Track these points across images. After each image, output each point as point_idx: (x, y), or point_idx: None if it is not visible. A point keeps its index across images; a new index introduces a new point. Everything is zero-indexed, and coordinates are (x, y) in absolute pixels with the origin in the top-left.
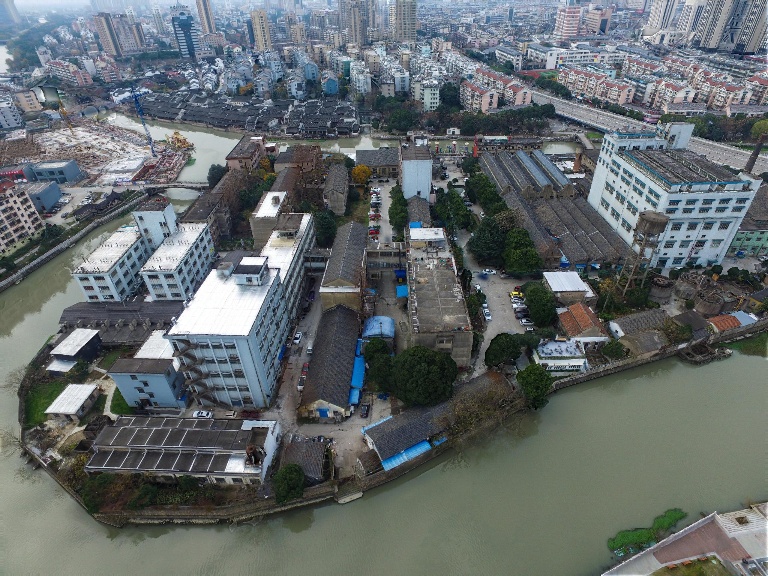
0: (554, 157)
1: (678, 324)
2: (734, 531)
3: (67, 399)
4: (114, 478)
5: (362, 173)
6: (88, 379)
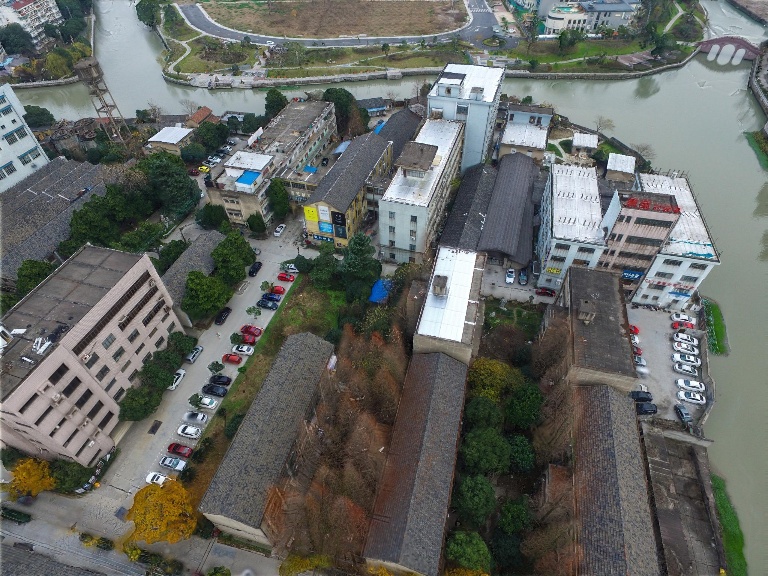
0: None
1: None
2: (250, 81)
3: (588, 139)
4: None
5: (170, 482)
6: (593, 164)
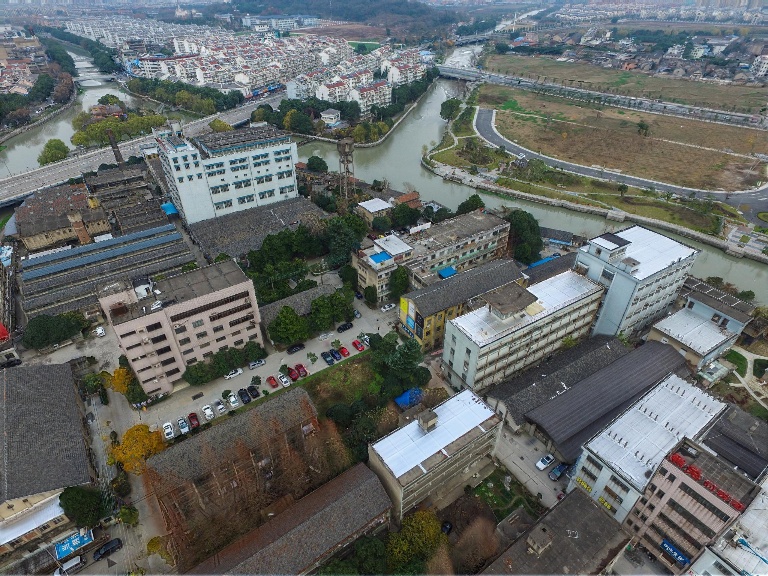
0: (7, 268)
1: (370, 187)
2: None
3: None
4: (735, 295)
5: (157, 432)
6: None
